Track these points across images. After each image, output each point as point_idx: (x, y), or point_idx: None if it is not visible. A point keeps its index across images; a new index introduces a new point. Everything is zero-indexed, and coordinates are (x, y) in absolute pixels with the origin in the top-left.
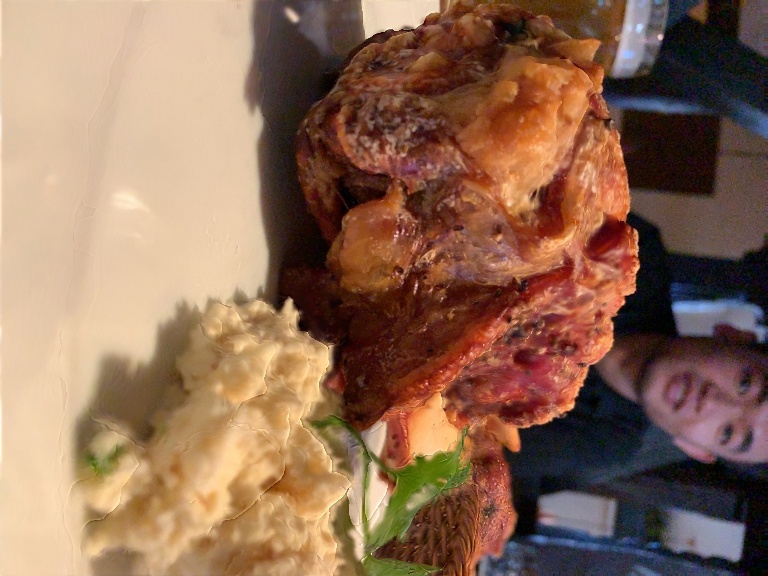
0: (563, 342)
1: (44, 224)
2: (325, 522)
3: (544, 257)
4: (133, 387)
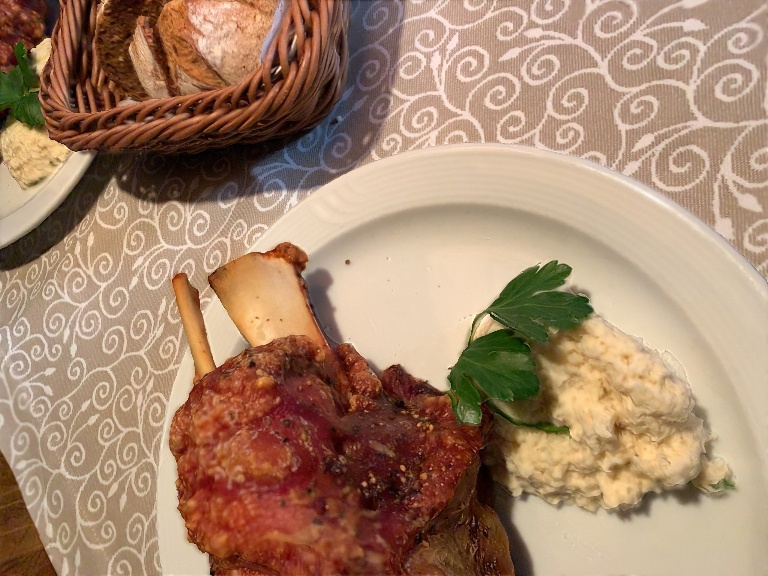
0: (338, 474)
1: None
2: (565, 379)
3: (430, 574)
4: (672, 492)
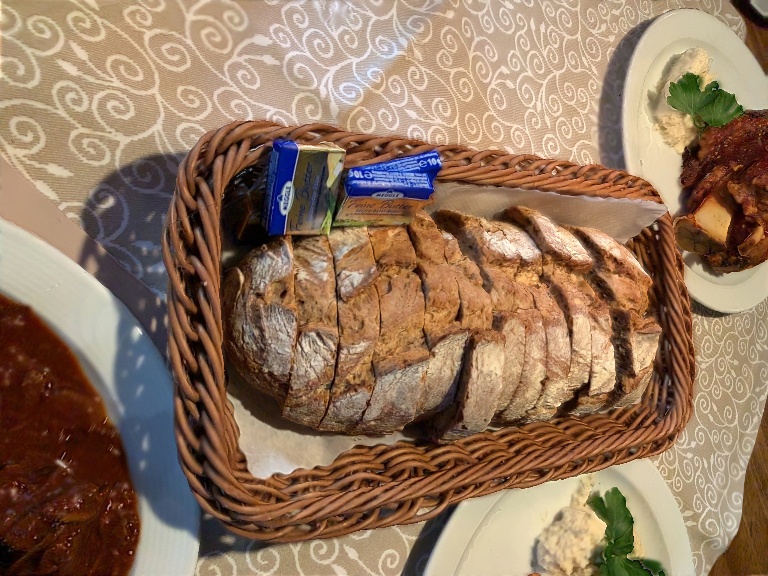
0: None
1: (718, 35)
2: None
3: None
4: None
